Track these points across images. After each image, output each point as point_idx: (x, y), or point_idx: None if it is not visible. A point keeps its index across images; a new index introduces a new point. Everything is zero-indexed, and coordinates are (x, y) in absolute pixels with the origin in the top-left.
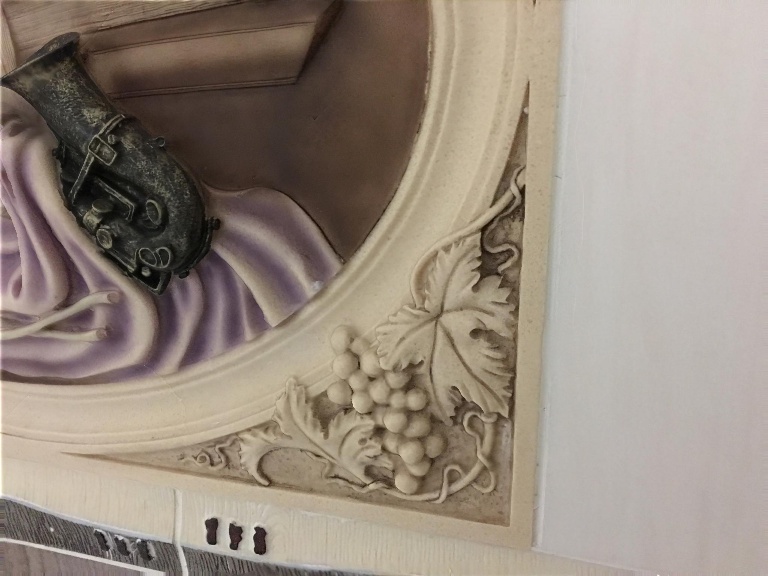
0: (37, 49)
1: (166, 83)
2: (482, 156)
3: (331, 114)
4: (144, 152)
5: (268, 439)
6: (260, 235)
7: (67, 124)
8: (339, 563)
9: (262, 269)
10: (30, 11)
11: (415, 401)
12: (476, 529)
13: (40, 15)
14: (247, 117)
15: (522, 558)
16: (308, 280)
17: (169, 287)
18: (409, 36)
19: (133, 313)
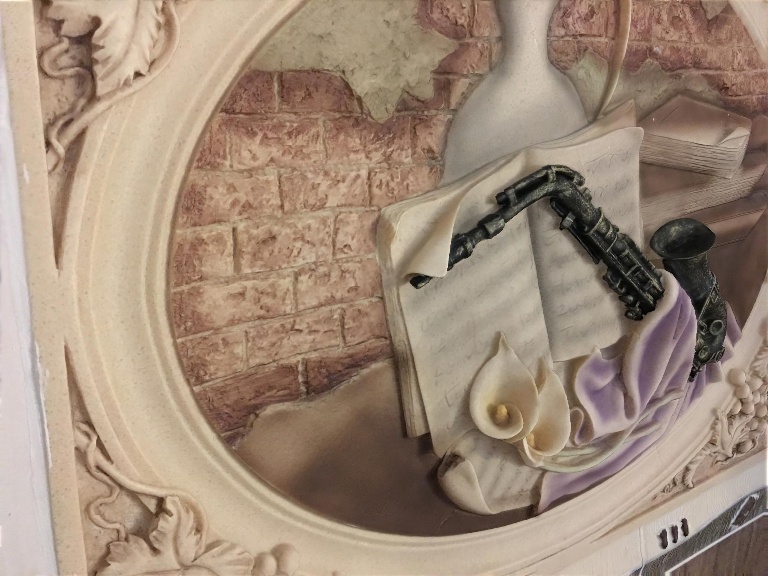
0: (650, 228)
1: None
2: None
3: None
4: None
5: None
6: None
7: (703, 281)
8: (714, 514)
9: None
10: (655, 202)
11: None
12: (760, 456)
13: (660, 205)
14: (725, 260)
15: (767, 462)
16: None
17: None
18: None
19: (674, 401)
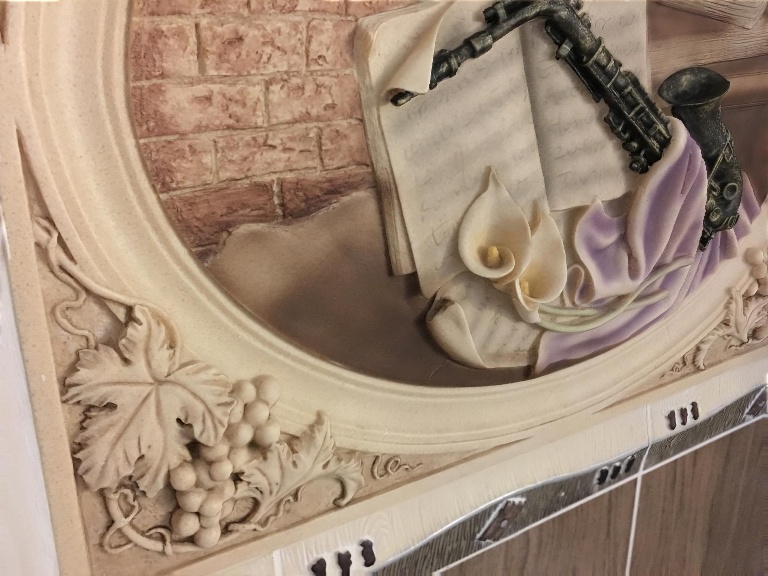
0: (659, 76)
1: None
2: None
3: None
4: None
5: (720, 333)
6: None
7: (716, 134)
8: (727, 401)
9: None
10: (664, 47)
11: None
12: None
13: (670, 51)
14: (743, 125)
15: None
16: None
17: None
18: None
19: (684, 270)
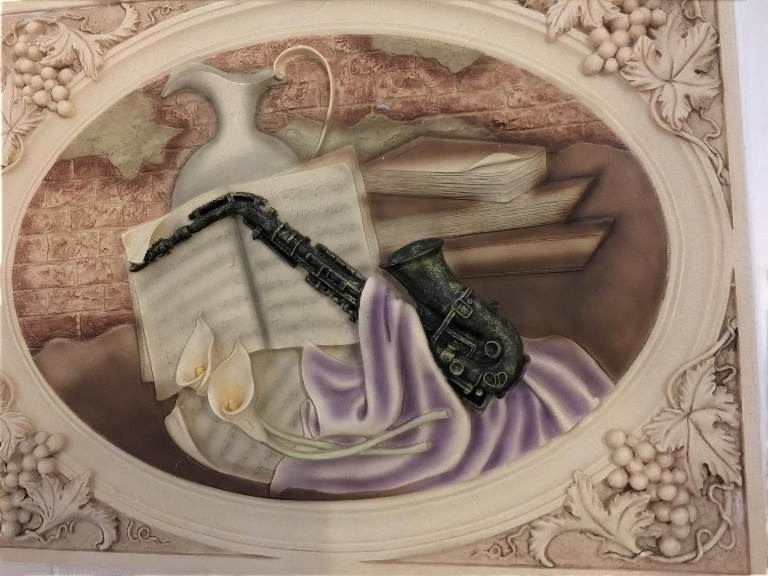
0: (395, 249)
1: (492, 270)
2: (708, 311)
3: (606, 288)
4: (488, 310)
5: (560, 522)
6: (554, 367)
7: (437, 292)
8: None
9: (554, 391)
10: (394, 226)
11: (680, 476)
12: None
13: (402, 228)
14: (547, 291)
15: None
16: (591, 396)
17: (487, 406)
18: (655, 244)
19: (456, 428)
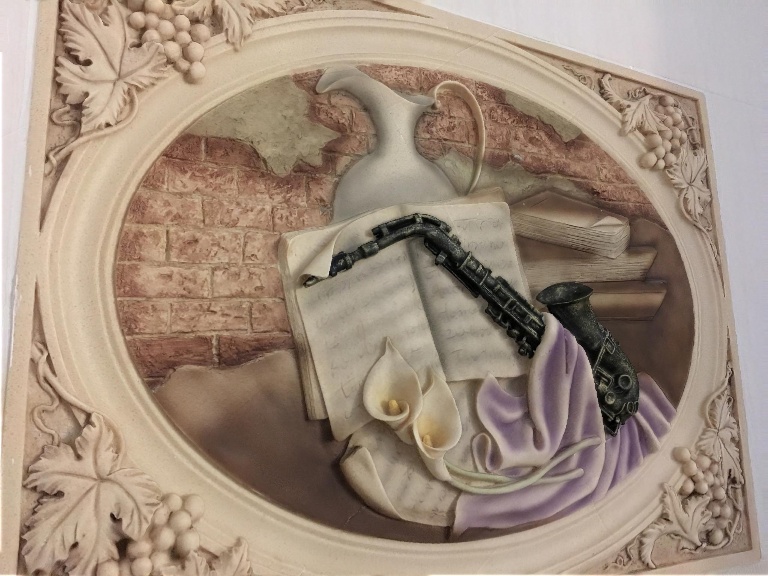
0: (538, 288)
1: (603, 314)
2: (718, 356)
3: (665, 335)
4: None
5: (661, 528)
6: (644, 398)
7: (592, 330)
8: None
9: None
10: (538, 267)
11: (723, 479)
12: (743, 556)
13: (544, 270)
14: (634, 335)
15: (757, 568)
16: None
17: None
18: None
19: (598, 453)
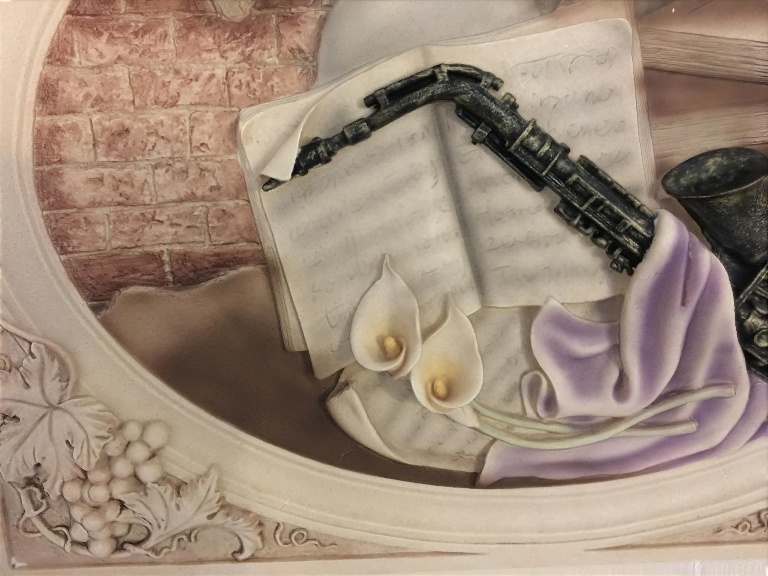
0: (675, 159)
1: None
2: None
3: None
4: None
5: None
6: None
7: (755, 235)
8: None
9: None
10: (680, 124)
11: None
12: None
13: (691, 128)
14: None
15: None
16: None
17: None
18: None
19: (732, 402)
